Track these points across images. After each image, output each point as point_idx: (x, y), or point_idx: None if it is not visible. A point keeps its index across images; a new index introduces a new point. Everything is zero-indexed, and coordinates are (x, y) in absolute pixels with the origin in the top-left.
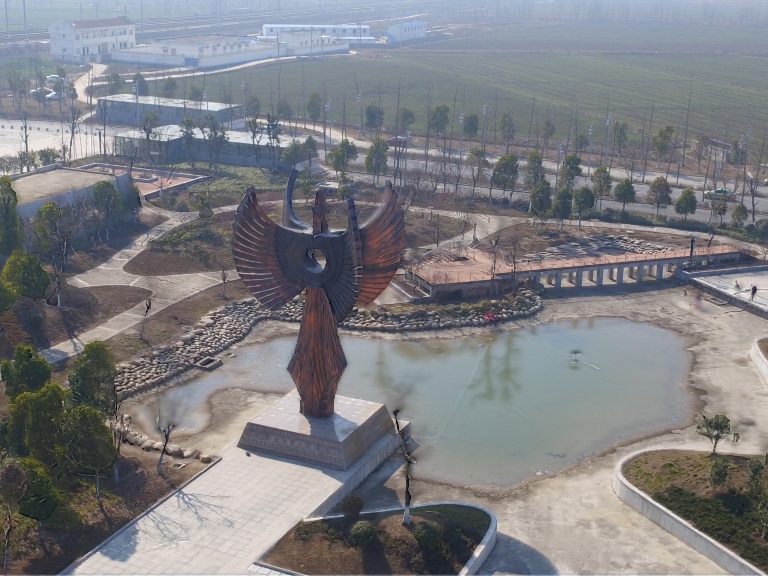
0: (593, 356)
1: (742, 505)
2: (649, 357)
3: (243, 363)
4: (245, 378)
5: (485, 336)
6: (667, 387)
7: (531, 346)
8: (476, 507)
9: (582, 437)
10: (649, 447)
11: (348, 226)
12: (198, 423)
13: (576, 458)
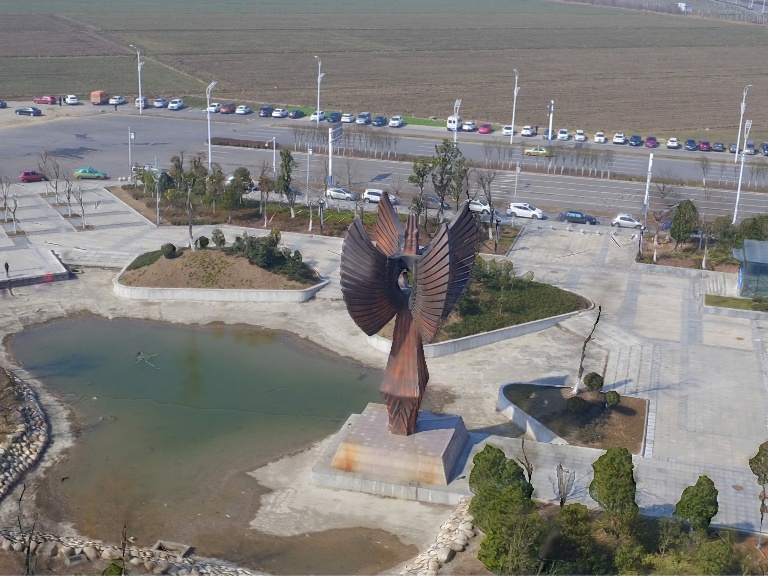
0: (124, 354)
1: (477, 309)
2: (130, 334)
3: (160, 529)
4: (214, 522)
5: (64, 396)
6: (207, 333)
7: (97, 377)
8: (504, 388)
9: (323, 367)
10: (338, 346)
11: (453, 228)
12: (359, 535)
13: (367, 370)
